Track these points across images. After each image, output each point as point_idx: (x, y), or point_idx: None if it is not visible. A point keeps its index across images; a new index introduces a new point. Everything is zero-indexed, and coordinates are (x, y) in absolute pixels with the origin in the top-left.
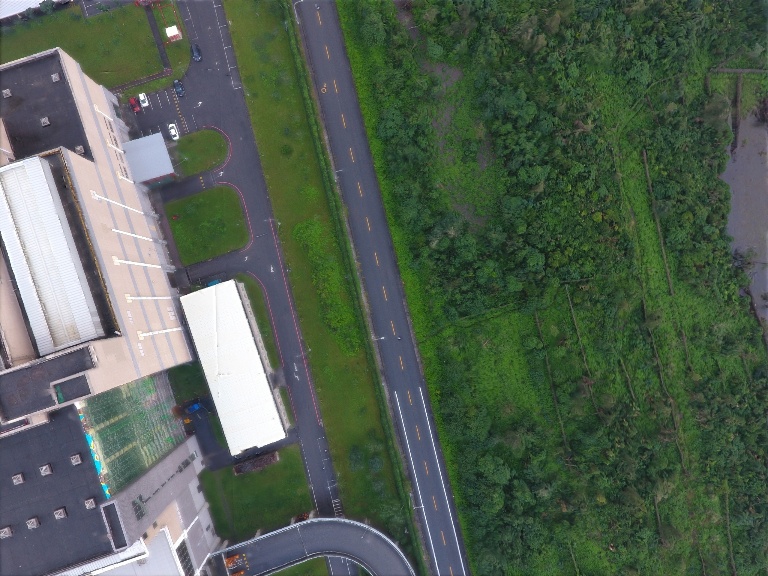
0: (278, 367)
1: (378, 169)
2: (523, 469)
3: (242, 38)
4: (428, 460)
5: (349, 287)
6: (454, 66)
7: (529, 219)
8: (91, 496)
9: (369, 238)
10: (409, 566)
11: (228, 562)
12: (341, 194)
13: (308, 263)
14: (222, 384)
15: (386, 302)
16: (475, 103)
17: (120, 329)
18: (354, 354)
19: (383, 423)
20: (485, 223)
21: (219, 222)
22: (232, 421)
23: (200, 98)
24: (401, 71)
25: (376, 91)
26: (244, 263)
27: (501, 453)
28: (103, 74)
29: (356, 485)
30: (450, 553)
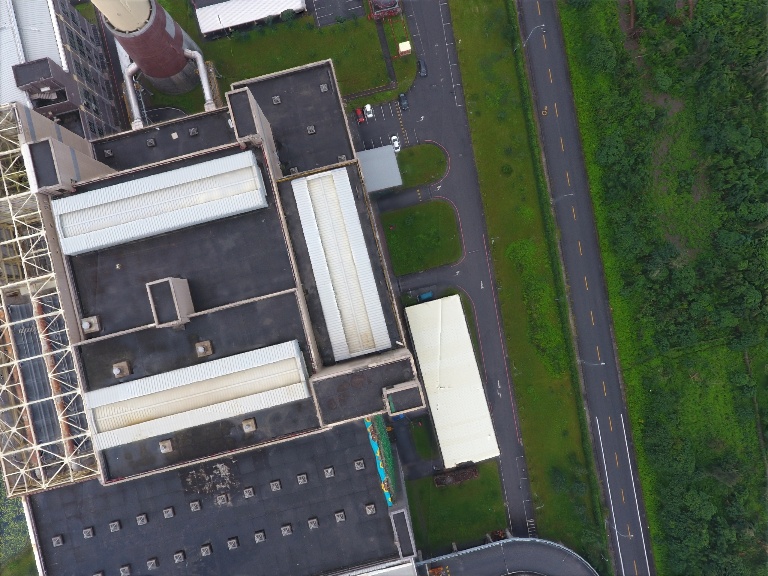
0: None
1: (595, 194)
2: (726, 506)
3: (469, 57)
4: (625, 488)
5: (559, 309)
6: (677, 97)
7: (746, 255)
8: (371, 502)
9: (580, 262)
10: None
11: (433, 573)
12: (555, 216)
13: (519, 282)
14: (442, 397)
15: (593, 327)
16: (694, 135)
17: (403, 340)
18: (559, 376)
19: (585, 447)
20: (696, 255)
21: (434, 235)
22: (449, 434)
23: (423, 113)
24: (627, 99)
25: (598, 117)
26: (455, 277)
27: (701, 488)
28: None
29: (552, 507)
30: None
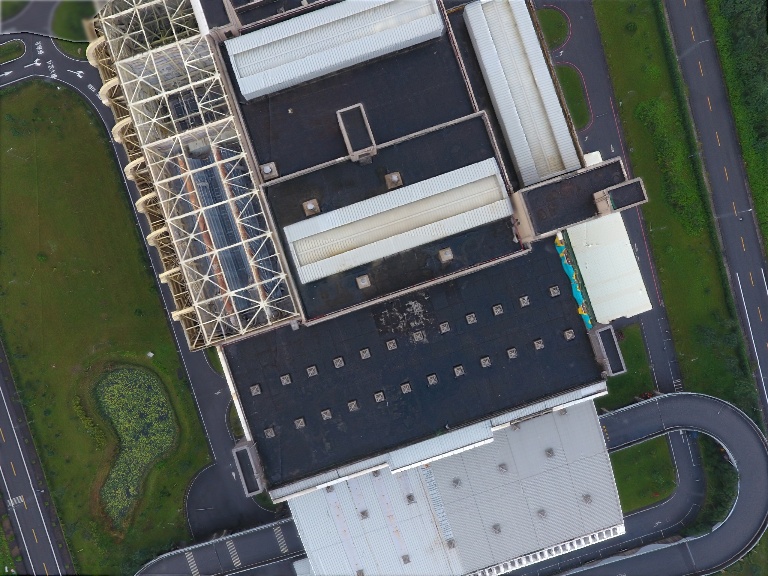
0: None
1: (722, 47)
2: None
3: None
4: None
5: (694, 166)
6: None
7: None
8: (569, 327)
9: (710, 118)
10: (766, 442)
11: None
12: (682, 73)
13: (651, 142)
14: (590, 254)
15: (727, 183)
16: None
17: (585, 166)
18: (697, 234)
19: (730, 302)
20: None
21: None
22: (600, 291)
23: None
24: None
25: None
26: (584, 143)
27: None
28: None
29: (698, 365)
30: None
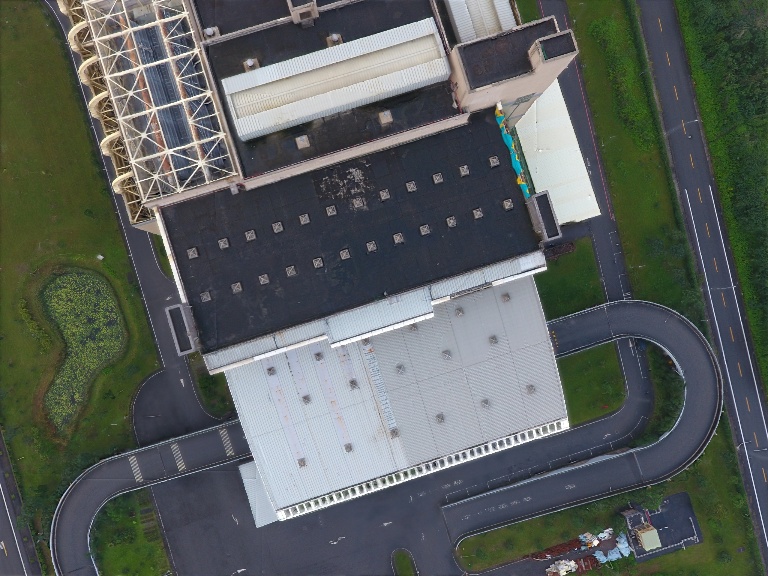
0: None
1: None
2: None
3: None
4: (717, 257)
5: (645, 83)
6: None
7: None
8: (508, 198)
9: (661, 38)
10: (712, 351)
11: None
12: None
13: (603, 59)
14: (541, 159)
15: (677, 101)
16: None
17: None
18: (647, 150)
19: (678, 216)
20: None
21: None
22: None
23: None
24: None
25: None
26: None
27: None
28: None
29: (648, 279)
30: (738, 349)
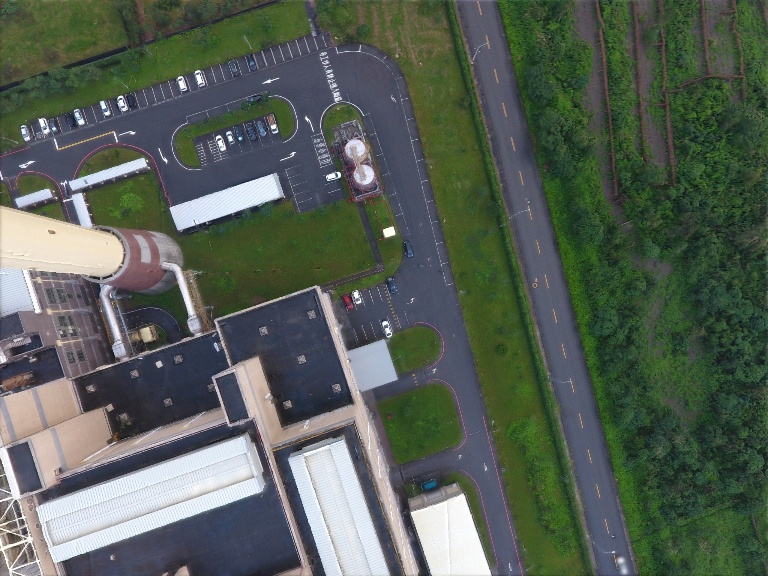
0: (493, 567)
1: (592, 366)
2: None
3: (455, 234)
4: None
5: (565, 487)
6: (666, 261)
7: (746, 419)
8: None
9: (582, 435)
10: None
11: None
12: (553, 390)
13: (523, 462)
14: None
15: (599, 500)
16: (686, 297)
17: None
18: (570, 554)
19: None
20: (696, 418)
21: (433, 421)
22: None
23: (412, 294)
24: (617, 270)
25: (590, 288)
26: (458, 461)
27: None
28: (315, 271)
29: None
30: None
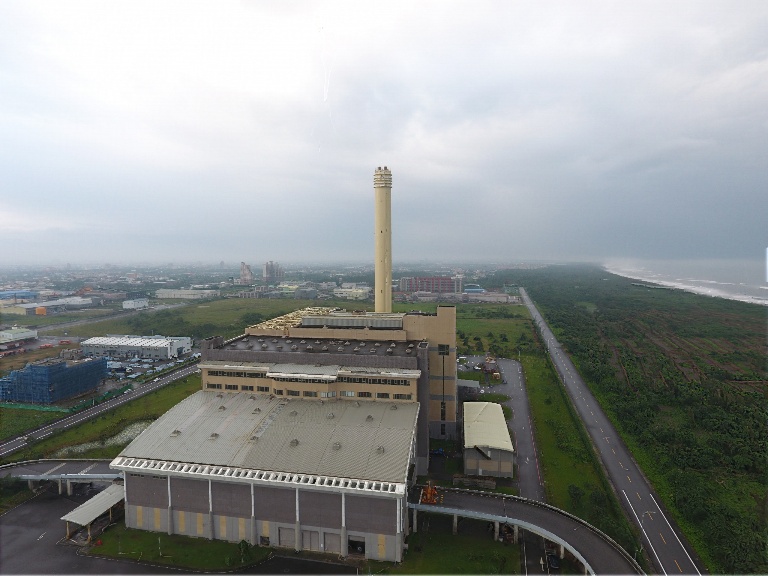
0: None
1: None
2: None
3: None
4: (664, 534)
5: None
6: (667, 405)
7: None
8: None
9: None
10: (639, 567)
11: None
12: None
13: None
14: None
15: None
16: (686, 416)
17: None
18: (582, 463)
19: (608, 493)
20: None
21: None
22: (474, 435)
23: None
24: None
25: None
26: None
27: None
28: None
29: None
30: None
